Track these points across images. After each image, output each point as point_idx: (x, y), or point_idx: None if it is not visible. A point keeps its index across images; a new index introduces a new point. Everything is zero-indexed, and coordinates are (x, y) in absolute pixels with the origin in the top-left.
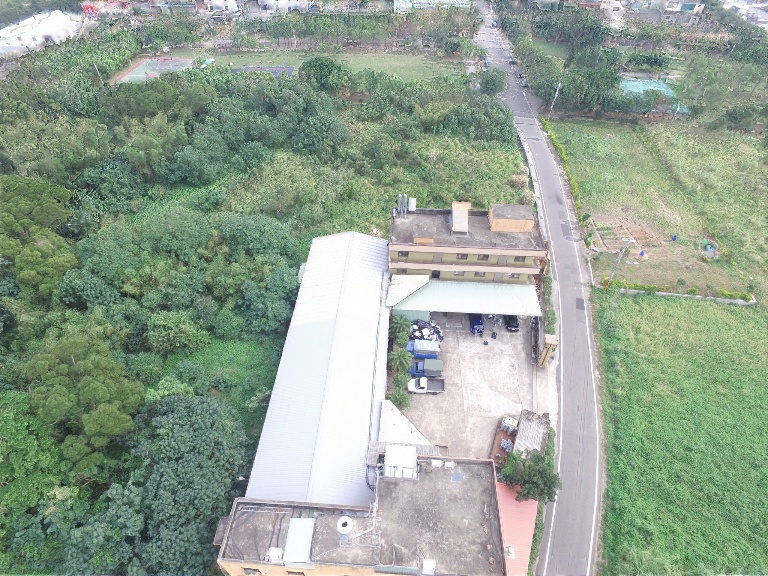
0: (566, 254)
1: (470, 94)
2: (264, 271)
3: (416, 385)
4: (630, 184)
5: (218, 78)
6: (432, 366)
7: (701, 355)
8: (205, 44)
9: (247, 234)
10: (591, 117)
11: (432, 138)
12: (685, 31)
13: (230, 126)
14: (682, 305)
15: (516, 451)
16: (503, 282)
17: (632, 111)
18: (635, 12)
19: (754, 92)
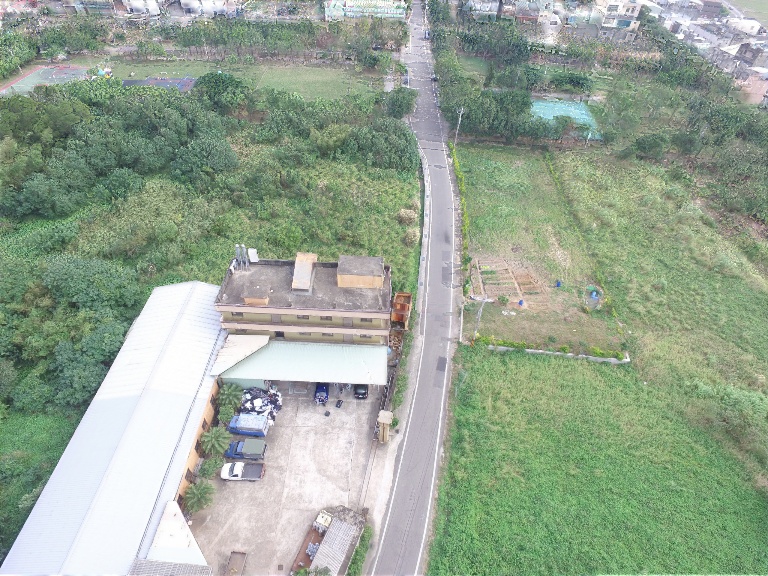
0: (440, 303)
1: (377, 115)
2: (83, 330)
3: (230, 472)
4: (527, 220)
5: (101, 93)
6: (251, 448)
7: (559, 426)
8: (112, 50)
9: (71, 285)
10: (502, 142)
11: (328, 164)
12: (619, 48)
13: (97, 150)
14: (551, 365)
15: (301, 572)
16: (353, 342)
17: (542, 138)
18: (572, 27)
19: (676, 116)
